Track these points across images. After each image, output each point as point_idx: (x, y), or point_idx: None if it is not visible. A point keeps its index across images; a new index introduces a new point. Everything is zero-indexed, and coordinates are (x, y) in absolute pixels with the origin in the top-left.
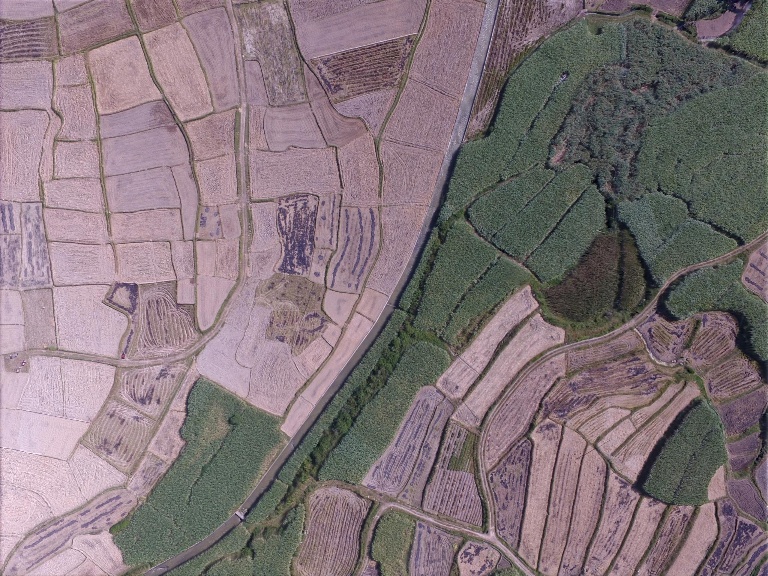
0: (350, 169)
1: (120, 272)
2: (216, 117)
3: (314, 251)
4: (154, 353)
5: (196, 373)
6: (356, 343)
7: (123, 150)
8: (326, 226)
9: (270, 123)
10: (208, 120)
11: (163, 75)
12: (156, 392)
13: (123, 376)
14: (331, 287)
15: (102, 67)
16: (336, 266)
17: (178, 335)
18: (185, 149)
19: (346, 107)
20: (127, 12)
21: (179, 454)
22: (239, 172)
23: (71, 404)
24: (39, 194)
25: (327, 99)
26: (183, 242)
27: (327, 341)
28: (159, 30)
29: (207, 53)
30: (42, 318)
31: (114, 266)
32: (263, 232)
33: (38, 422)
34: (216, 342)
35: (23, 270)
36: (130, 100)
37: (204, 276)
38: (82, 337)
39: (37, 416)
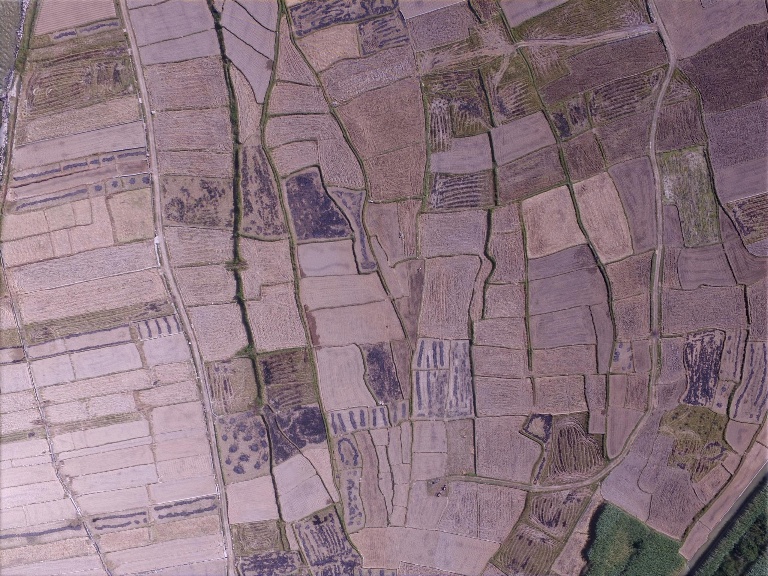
0: (758, 306)
1: (537, 404)
2: (634, 259)
3: (718, 383)
4: (563, 479)
5: (600, 498)
6: (754, 471)
7: (547, 291)
8: (731, 360)
9: (683, 263)
10: (627, 262)
11: (589, 221)
12: (563, 515)
13: (533, 500)
14: (734, 418)
15: (533, 215)
16: (739, 398)
17: (586, 462)
18: (604, 289)
19: (757, 247)
20: (560, 164)
21: (581, 574)
22: (652, 310)
23: (485, 526)
24: (468, 332)
25: (739, 240)
26: (597, 376)
27: (727, 469)
28: (588, 180)
29: (629, 199)
30: (462, 446)
31: (532, 398)
32: (670, 365)
33: (453, 542)
34: (620, 469)
35: (448, 402)
36: (557, 245)
37: (614, 407)
38: (499, 464)
39: (453, 537)
